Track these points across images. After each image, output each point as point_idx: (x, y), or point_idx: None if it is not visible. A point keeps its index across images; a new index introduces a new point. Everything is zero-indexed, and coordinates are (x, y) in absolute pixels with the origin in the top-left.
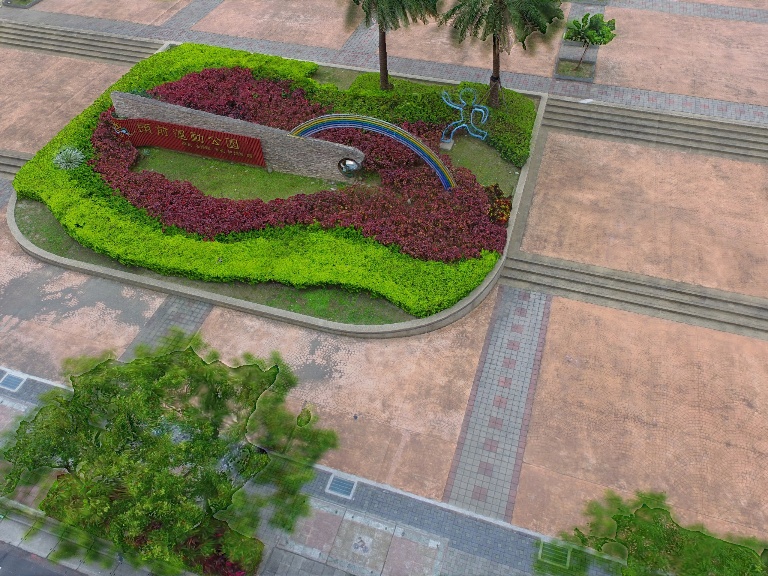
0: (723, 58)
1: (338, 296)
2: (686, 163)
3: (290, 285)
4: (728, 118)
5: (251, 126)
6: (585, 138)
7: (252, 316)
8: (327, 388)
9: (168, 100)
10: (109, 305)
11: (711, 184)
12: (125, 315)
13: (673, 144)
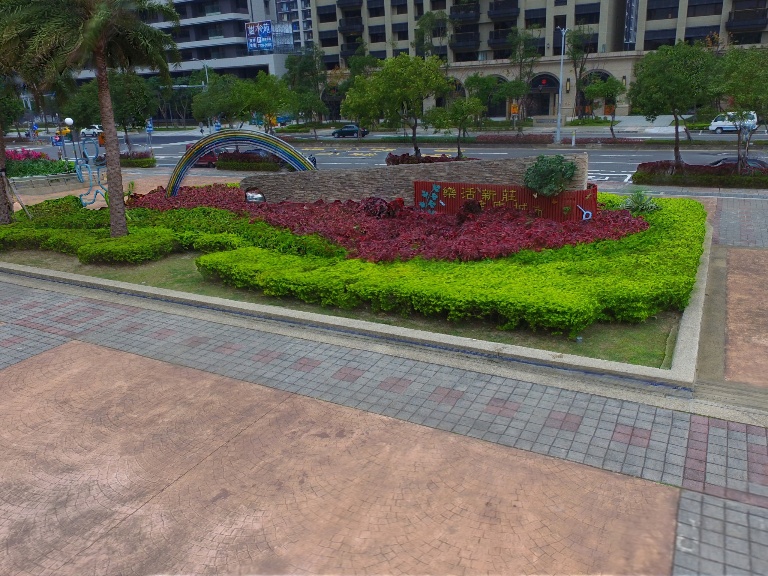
0: None
1: None
2: None
3: None
4: None
5: None
6: None
7: None
8: None
9: None
10: None
11: None
12: None
13: None
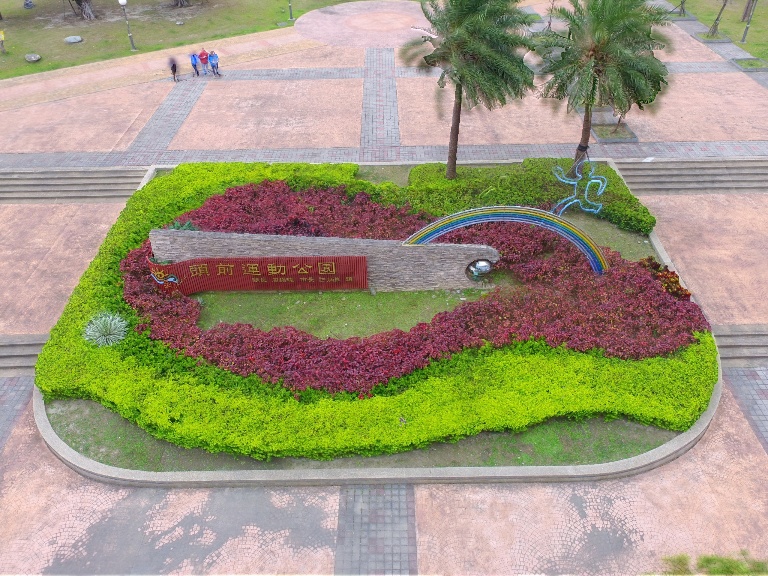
0: (727, 105)
1: (564, 429)
2: None
3: (504, 431)
4: None
5: (353, 242)
6: (669, 196)
7: (472, 486)
8: (639, 560)
9: (203, 231)
10: (265, 526)
11: None
12: (298, 535)
13: (752, 187)
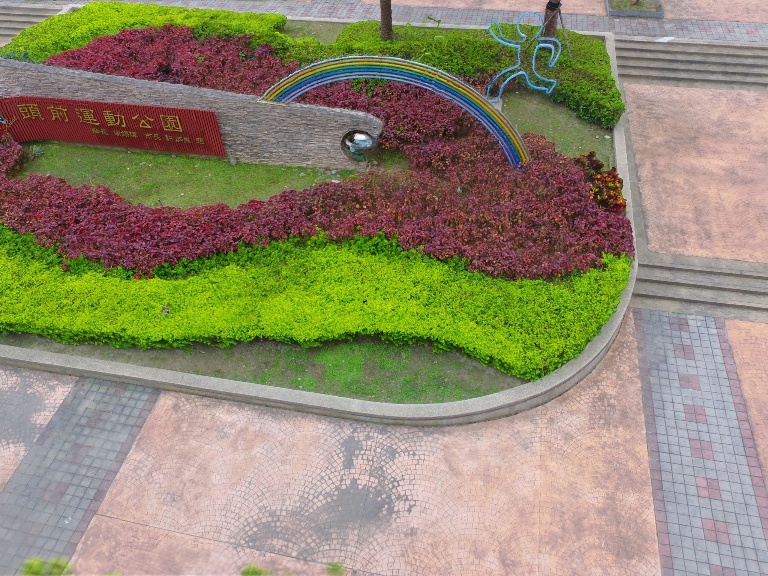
0: None
1: (376, 354)
2: None
3: (292, 343)
4: None
5: (199, 92)
6: (677, 87)
7: (230, 404)
8: (389, 537)
9: None
10: None
11: None
12: None
13: None
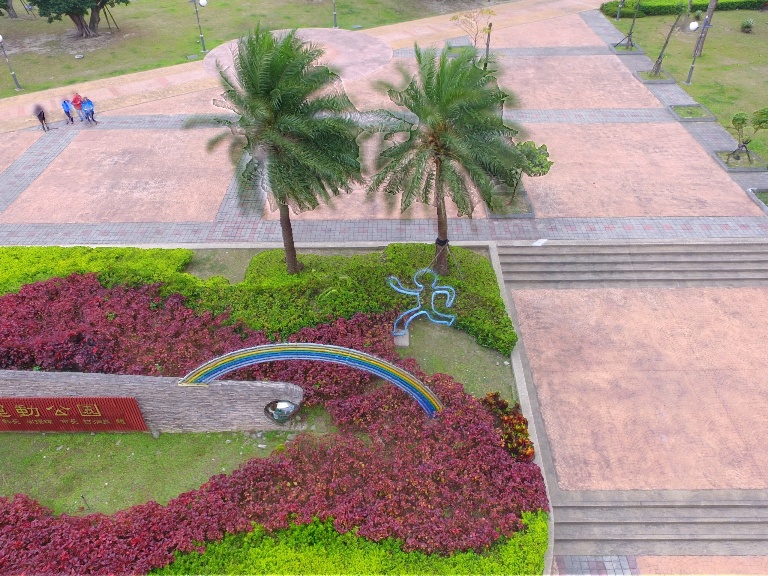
0: (650, 166)
1: None
2: (684, 302)
3: None
4: (700, 238)
5: (117, 381)
6: (556, 290)
7: None
8: None
9: None
10: None
11: (727, 326)
12: None
13: (656, 280)
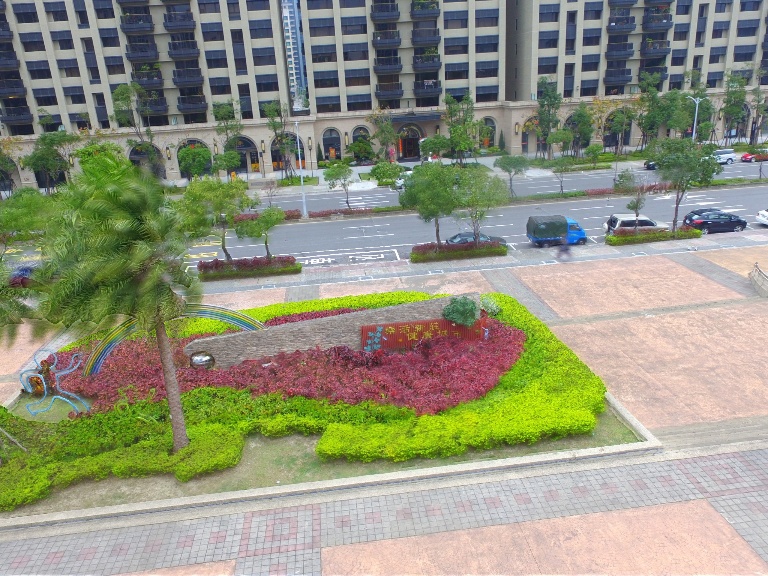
0: None
1: None
2: None
3: None
4: None
5: (311, 320)
6: None
7: None
8: None
9: None
10: None
11: None
12: None
13: None
